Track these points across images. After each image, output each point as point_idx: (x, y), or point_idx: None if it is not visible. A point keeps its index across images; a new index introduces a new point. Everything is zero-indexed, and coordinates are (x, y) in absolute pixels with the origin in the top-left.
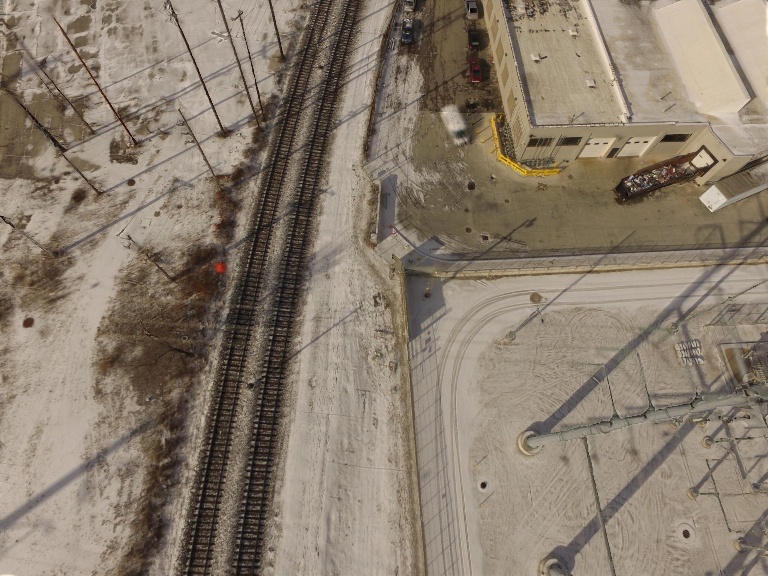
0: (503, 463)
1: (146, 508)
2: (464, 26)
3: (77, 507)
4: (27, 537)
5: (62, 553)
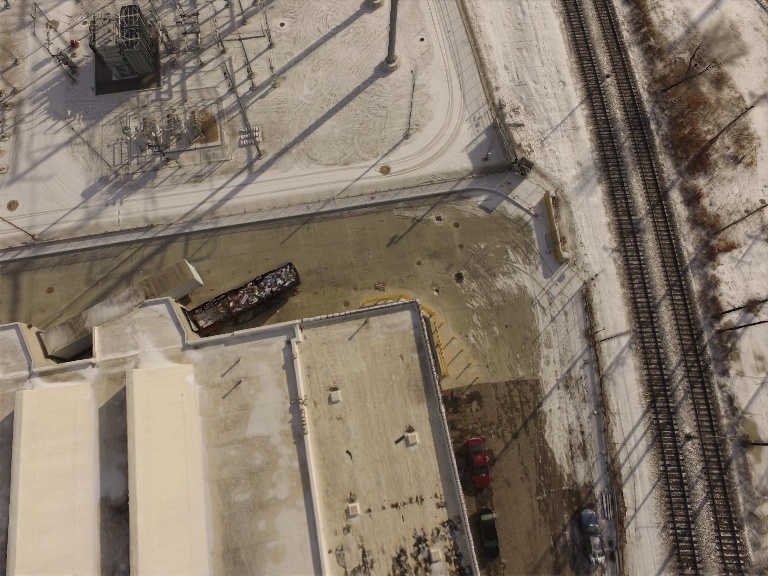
0: (409, 52)
1: (642, 7)
2: (506, 574)
3: (684, 5)
4: None
5: None
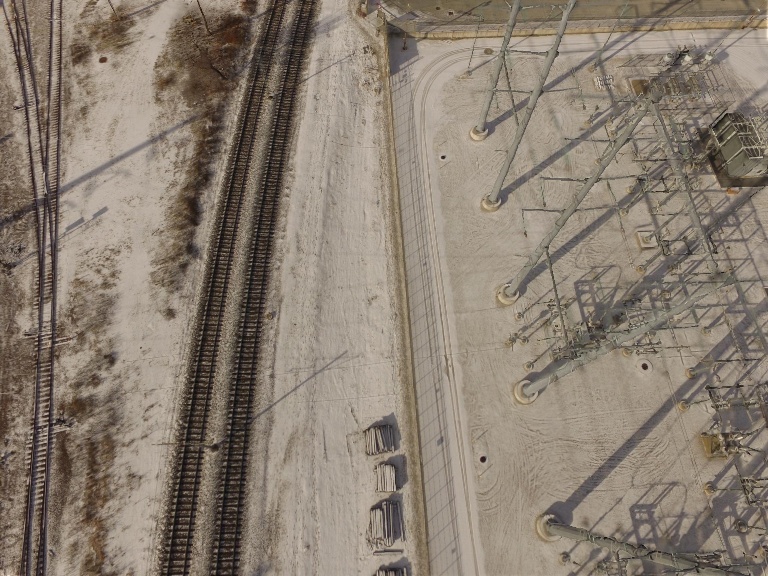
0: (458, 145)
1: (196, 163)
2: None
3: (147, 163)
4: (112, 179)
5: (138, 187)
